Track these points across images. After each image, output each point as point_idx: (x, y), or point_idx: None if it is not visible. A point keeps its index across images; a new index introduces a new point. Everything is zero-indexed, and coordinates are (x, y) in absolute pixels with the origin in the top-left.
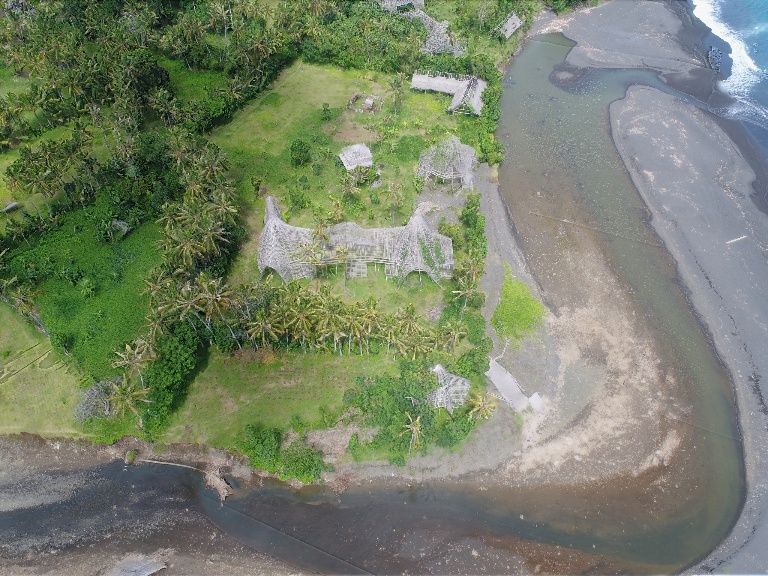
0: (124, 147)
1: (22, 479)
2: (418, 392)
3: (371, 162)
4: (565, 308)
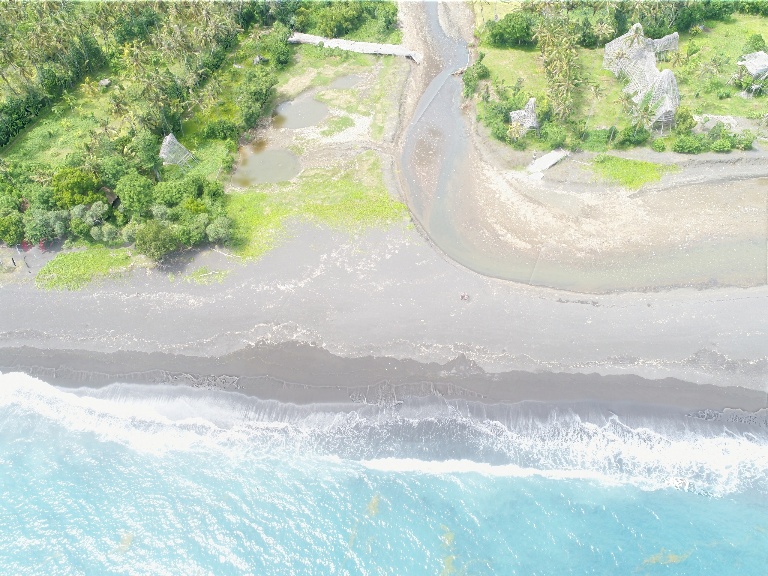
0: None
1: (455, 23)
2: (516, 99)
3: (755, 71)
4: (640, 201)
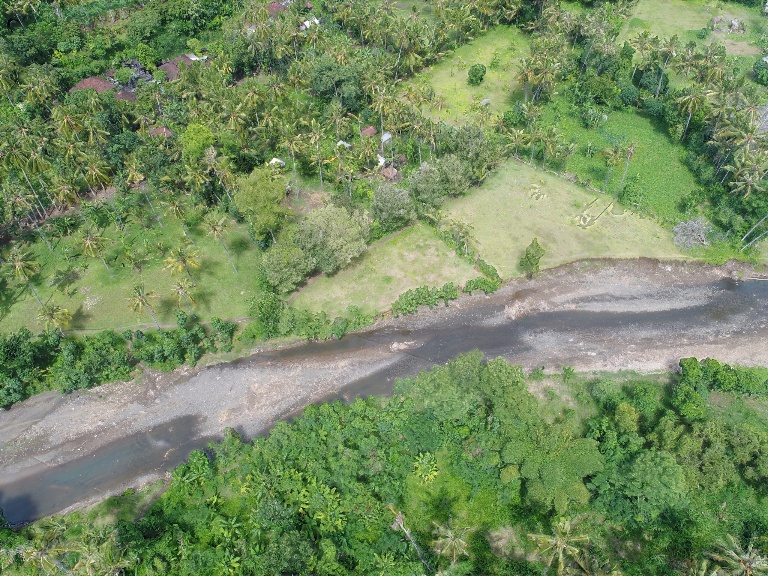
0: (609, 45)
1: (658, 290)
2: None
3: None
4: None
